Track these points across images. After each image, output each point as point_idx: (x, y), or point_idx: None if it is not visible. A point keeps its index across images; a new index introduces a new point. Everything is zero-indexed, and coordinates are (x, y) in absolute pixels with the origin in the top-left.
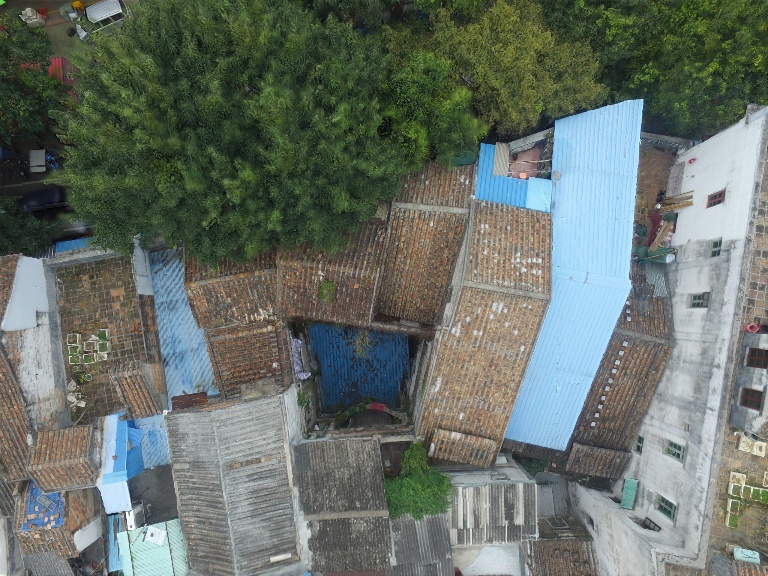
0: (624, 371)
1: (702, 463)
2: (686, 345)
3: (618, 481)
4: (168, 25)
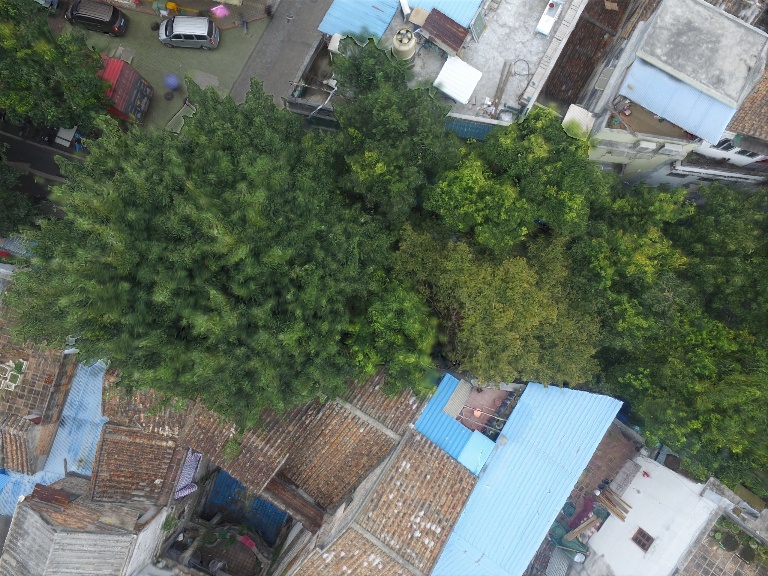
0: None
1: None
2: None
3: None
4: None
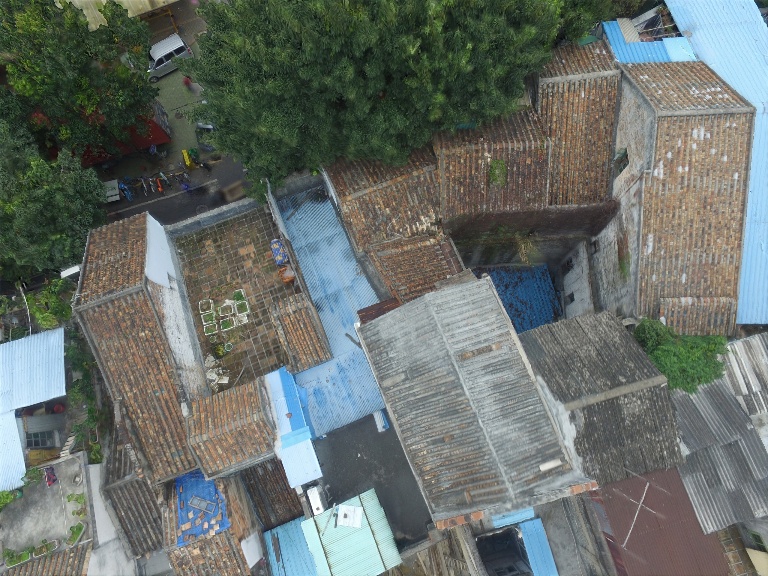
0: None
1: None
2: None
3: None
4: None
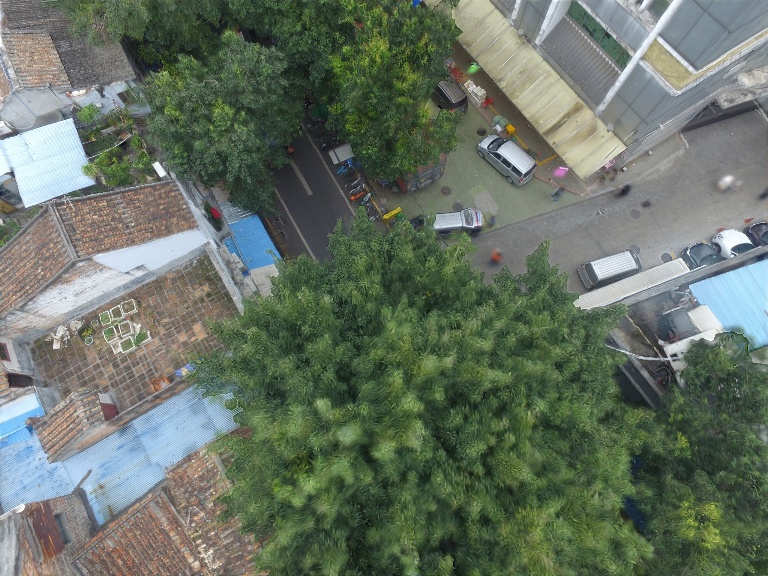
0: None
1: None
2: None
3: None
4: None
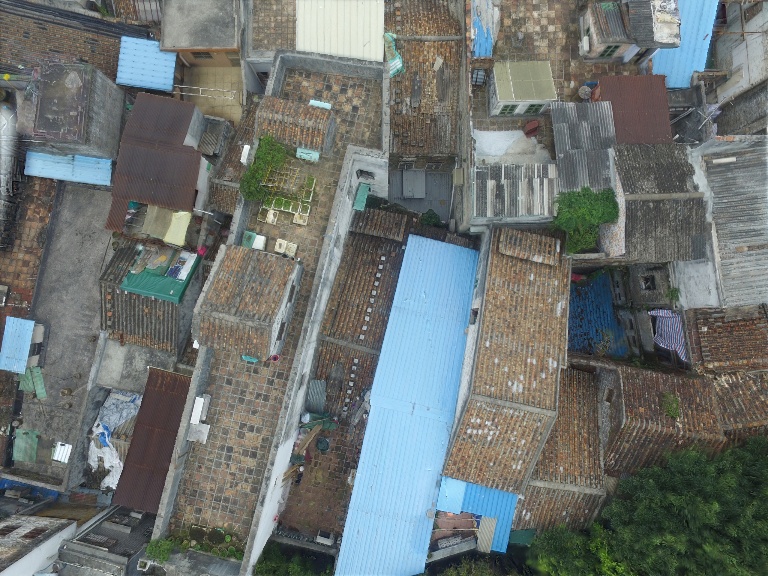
0: (359, 309)
1: None
2: None
3: None
4: None
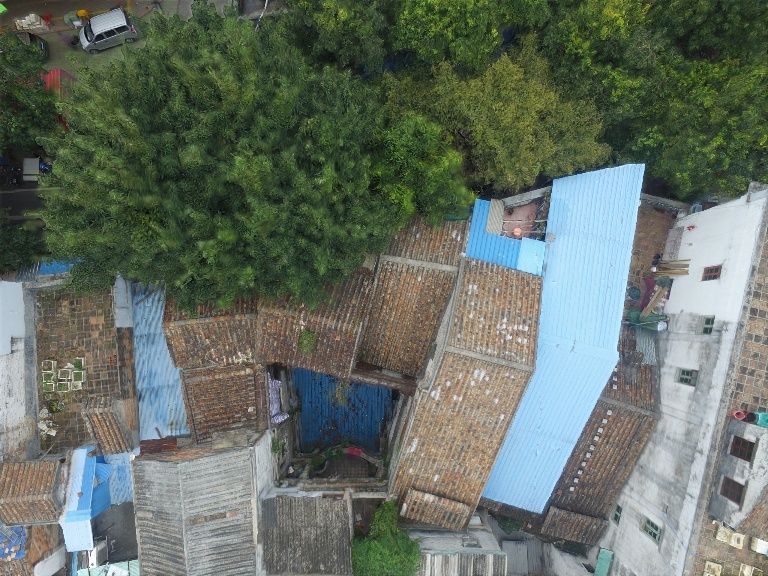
0: (607, 439)
1: (677, 551)
2: (671, 421)
3: (593, 547)
4: (157, 72)
